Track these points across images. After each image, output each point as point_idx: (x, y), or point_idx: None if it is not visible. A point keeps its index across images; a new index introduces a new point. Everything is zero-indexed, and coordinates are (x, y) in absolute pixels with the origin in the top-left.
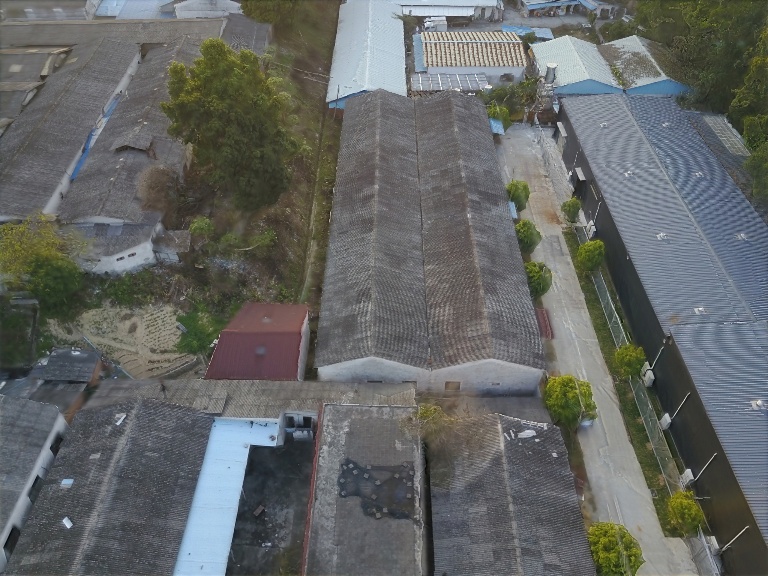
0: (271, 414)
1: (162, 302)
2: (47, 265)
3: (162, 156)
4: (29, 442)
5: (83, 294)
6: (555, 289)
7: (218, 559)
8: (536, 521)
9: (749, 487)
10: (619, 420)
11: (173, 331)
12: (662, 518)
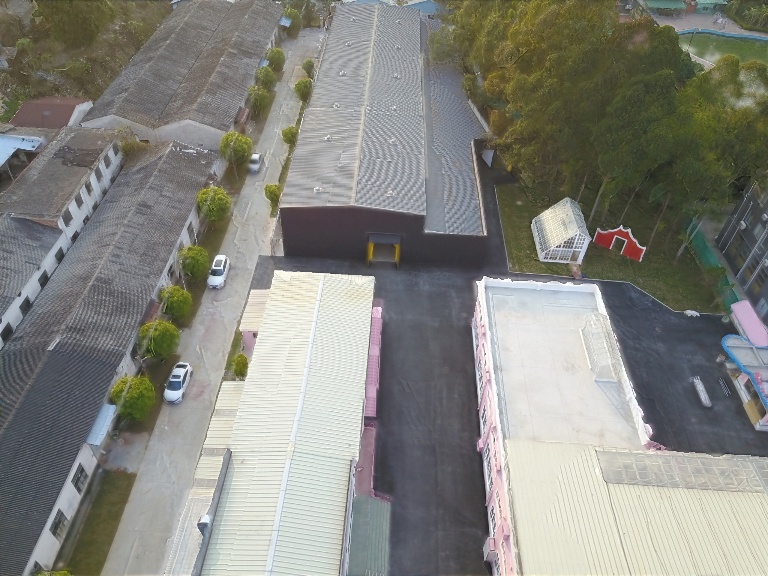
0: (36, 135)
1: None
2: None
3: (13, 7)
4: None
5: None
6: (280, 113)
7: None
8: (168, 181)
9: (294, 167)
10: (278, 172)
11: None
12: (273, 210)
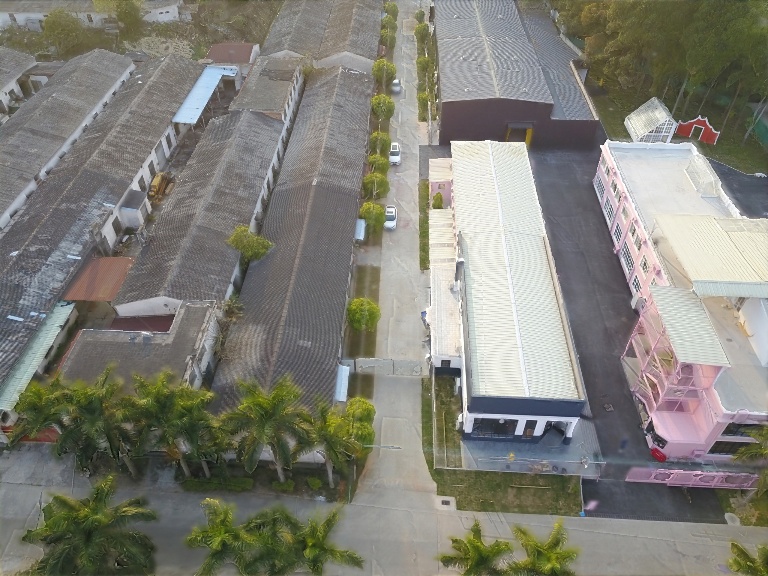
0: (234, 65)
1: (182, 38)
2: (127, 0)
3: None
4: (120, 65)
5: (142, 29)
6: (402, 53)
7: (205, 98)
8: (347, 91)
9: (443, 77)
10: (415, 92)
11: (188, 52)
12: (420, 117)
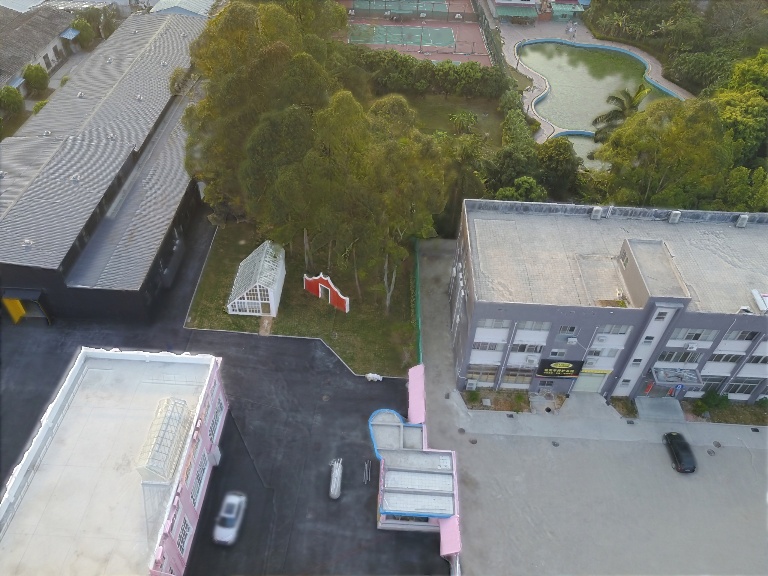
0: None
1: None
2: None
3: None
4: None
5: None
6: None
7: None
8: None
9: None
10: None
11: None
12: None
